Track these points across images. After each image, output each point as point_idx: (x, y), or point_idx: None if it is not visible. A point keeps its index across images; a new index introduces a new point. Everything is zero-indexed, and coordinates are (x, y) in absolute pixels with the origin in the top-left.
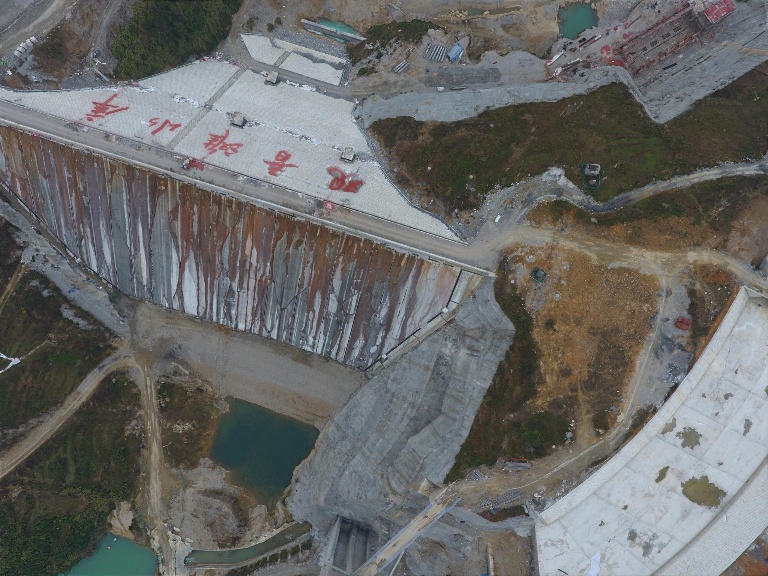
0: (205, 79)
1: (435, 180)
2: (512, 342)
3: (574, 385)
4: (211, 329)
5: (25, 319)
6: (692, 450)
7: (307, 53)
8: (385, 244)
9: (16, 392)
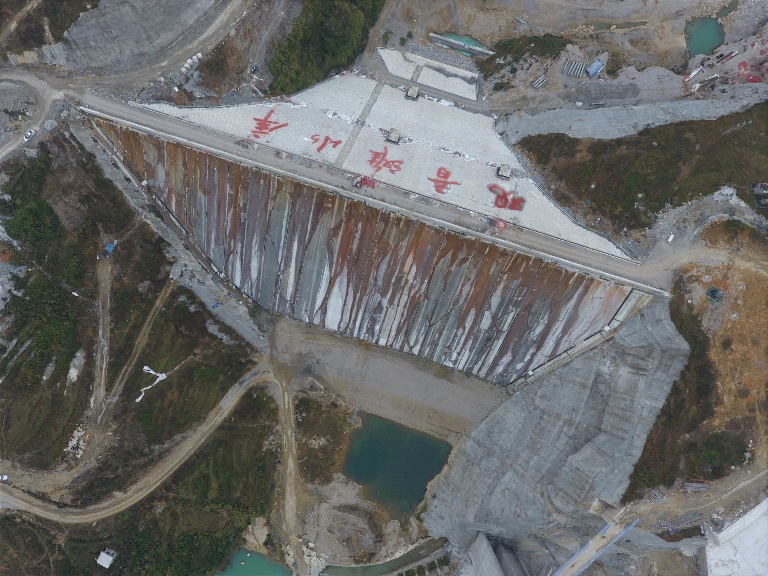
0: (350, 94)
1: (602, 198)
2: (687, 362)
3: (752, 405)
4: (351, 344)
5: (173, 334)
6: None
7: (439, 67)
8: (556, 263)
9: (163, 408)
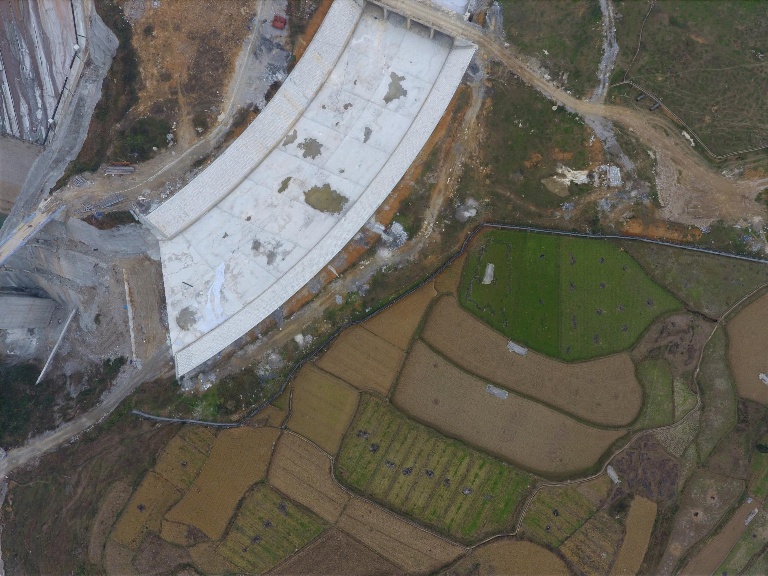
0: None
1: None
2: None
3: (174, 88)
4: None
5: None
6: (313, 160)
7: None
8: None
9: None
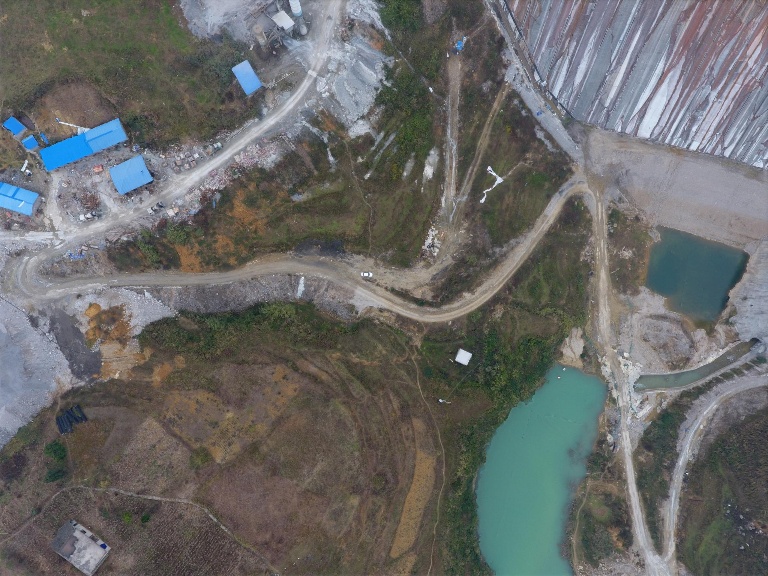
0: None
1: None
2: None
3: None
4: (663, 150)
5: (508, 137)
6: None
7: None
8: None
9: (502, 210)
